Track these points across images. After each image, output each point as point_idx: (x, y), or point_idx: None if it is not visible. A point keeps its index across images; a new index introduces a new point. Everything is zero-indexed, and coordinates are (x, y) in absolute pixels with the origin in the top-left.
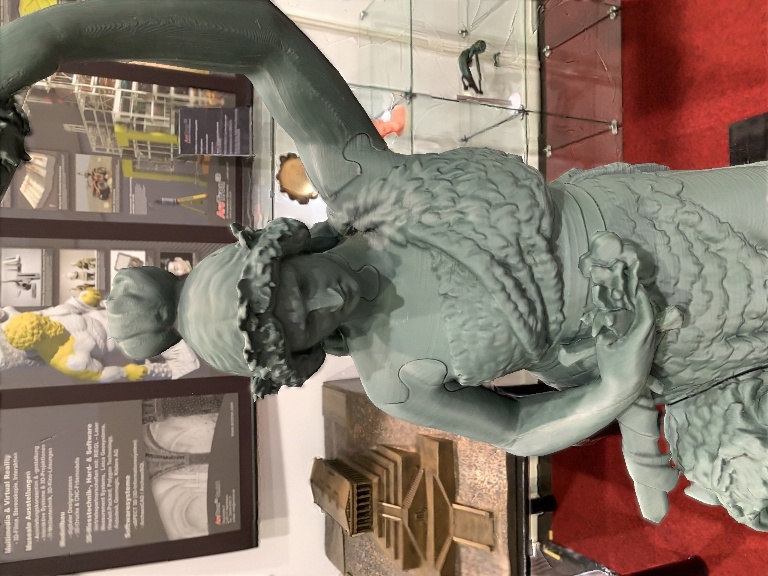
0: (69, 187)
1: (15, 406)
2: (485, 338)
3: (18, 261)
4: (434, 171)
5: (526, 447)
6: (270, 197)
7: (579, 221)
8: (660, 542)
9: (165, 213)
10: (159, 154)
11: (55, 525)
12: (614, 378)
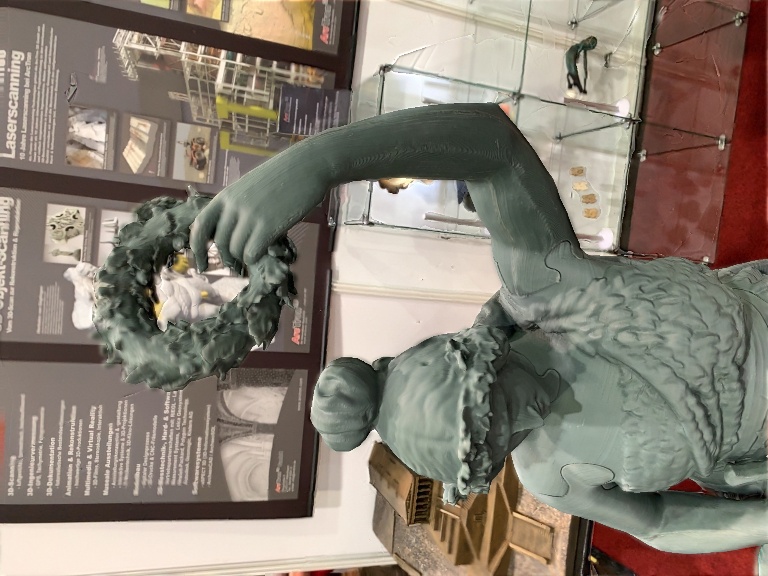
0: (168, 155)
1: (103, 361)
2: (664, 460)
3: (116, 223)
4: (636, 289)
5: (667, 545)
6: None
7: (767, 344)
8: (706, 567)
9: None
10: (256, 128)
11: (130, 475)
12: None
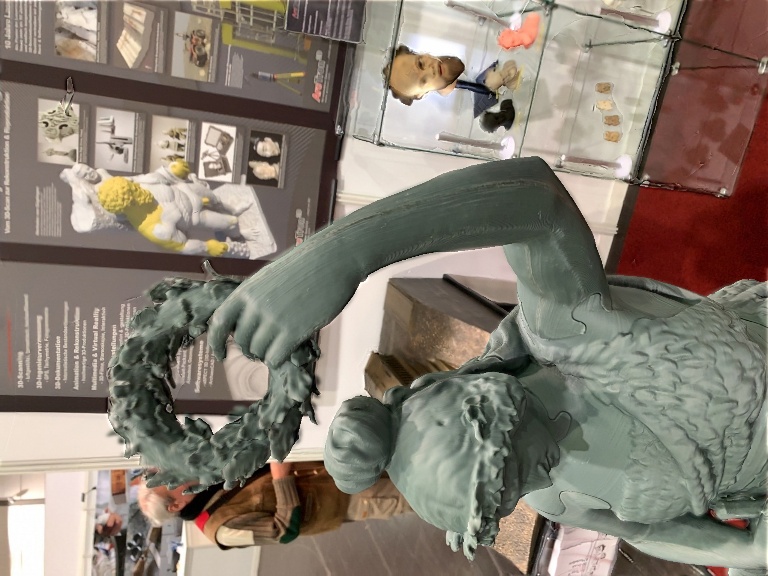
0: (166, 48)
1: (104, 265)
2: (662, 506)
3: (112, 123)
4: (662, 349)
5: (648, 550)
6: (381, 109)
7: None
8: None
9: (260, 88)
10: (261, 21)
11: None
12: None
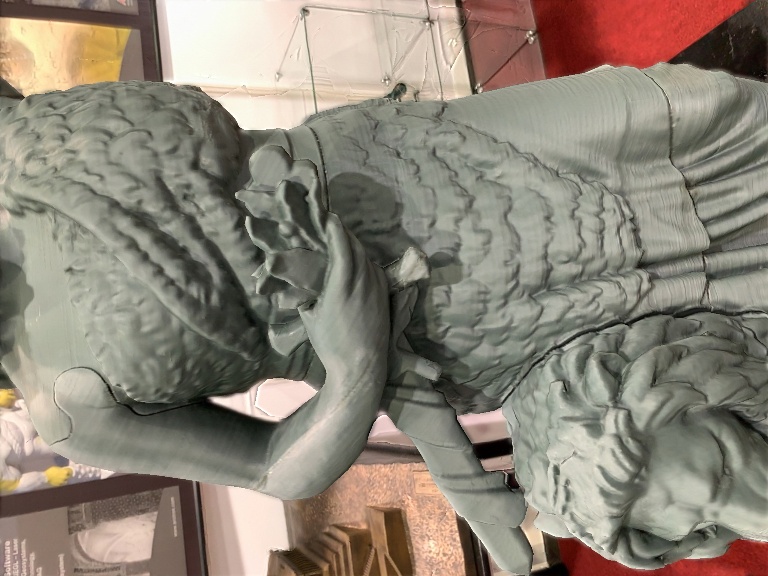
0: None
1: None
2: (124, 322)
3: None
4: (43, 107)
5: (280, 485)
6: None
7: None
8: None
9: None
10: None
11: None
12: (330, 358)
